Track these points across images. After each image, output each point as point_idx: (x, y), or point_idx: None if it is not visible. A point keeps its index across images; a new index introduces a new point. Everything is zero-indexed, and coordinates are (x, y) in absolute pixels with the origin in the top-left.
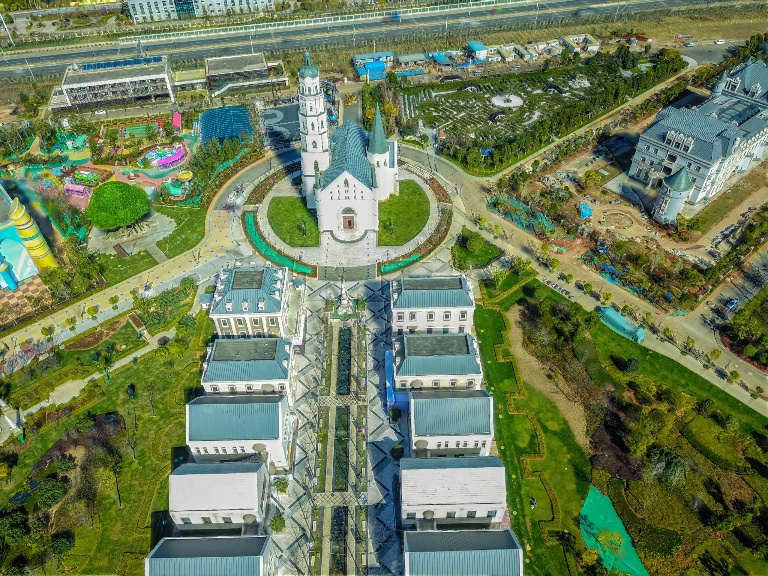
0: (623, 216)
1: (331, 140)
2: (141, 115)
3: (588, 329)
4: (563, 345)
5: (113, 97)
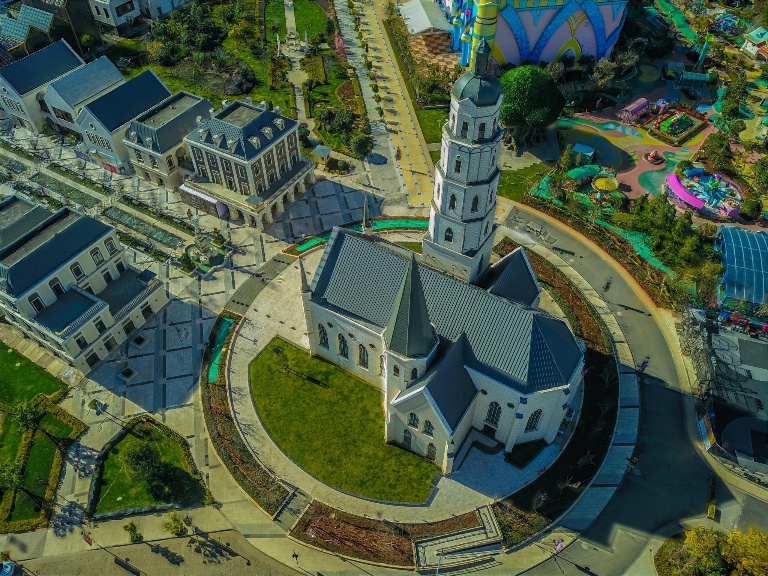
0: None
1: None
2: None
3: None
4: None
5: None
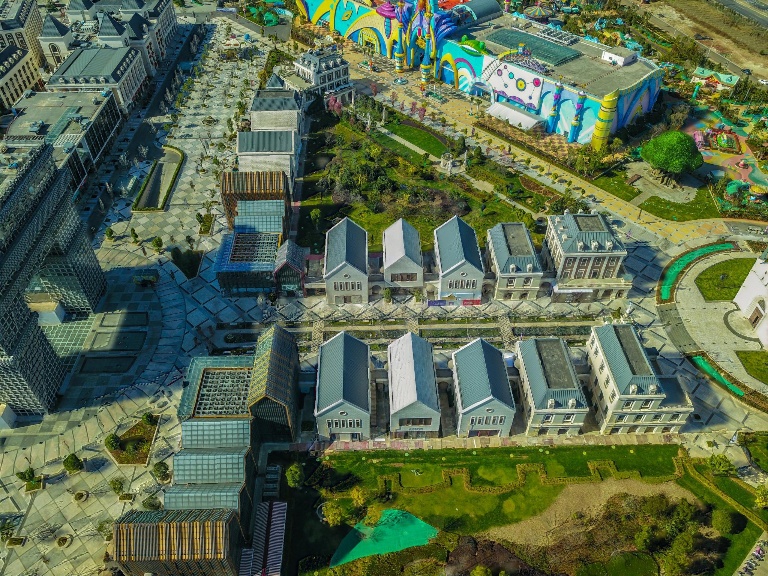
0: None
1: None
2: None
3: (665, 566)
4: None
5: None
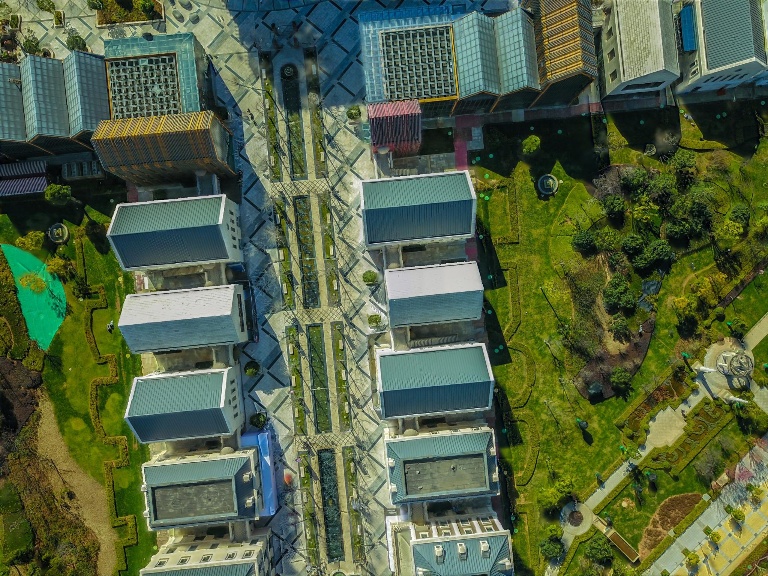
0: None
1: None
2: None
3: (4, 571)
4: (46, 548)
5: None
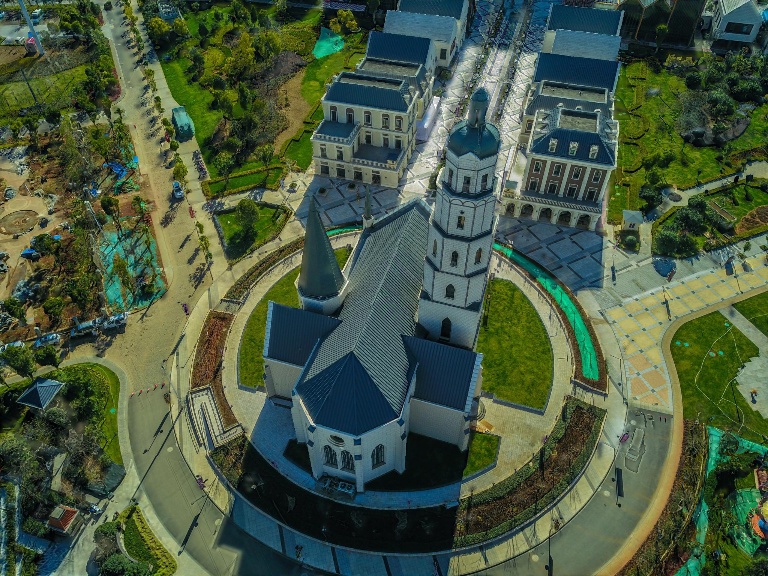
0: (2, 227)
1: (404, 370)
2: None
3: None
4: None
5: None
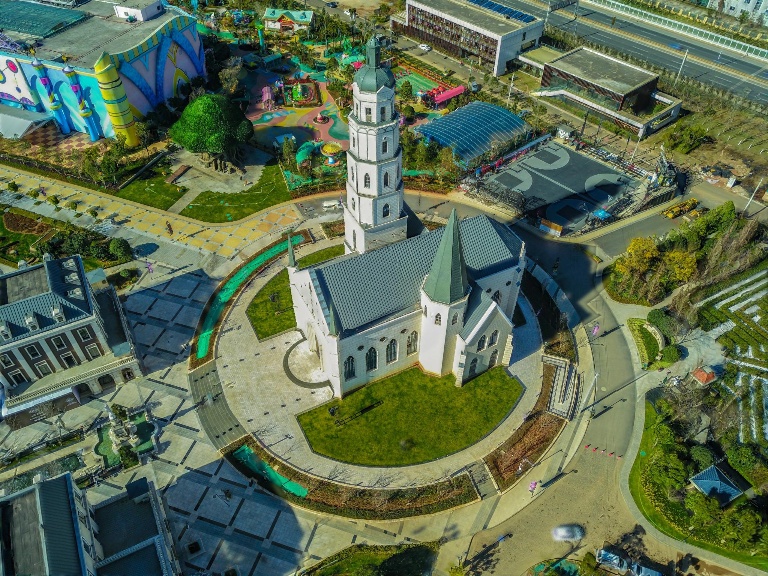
0: None
1: None
2: (445, 70)
3: None
4: None
5: (444, 37)
